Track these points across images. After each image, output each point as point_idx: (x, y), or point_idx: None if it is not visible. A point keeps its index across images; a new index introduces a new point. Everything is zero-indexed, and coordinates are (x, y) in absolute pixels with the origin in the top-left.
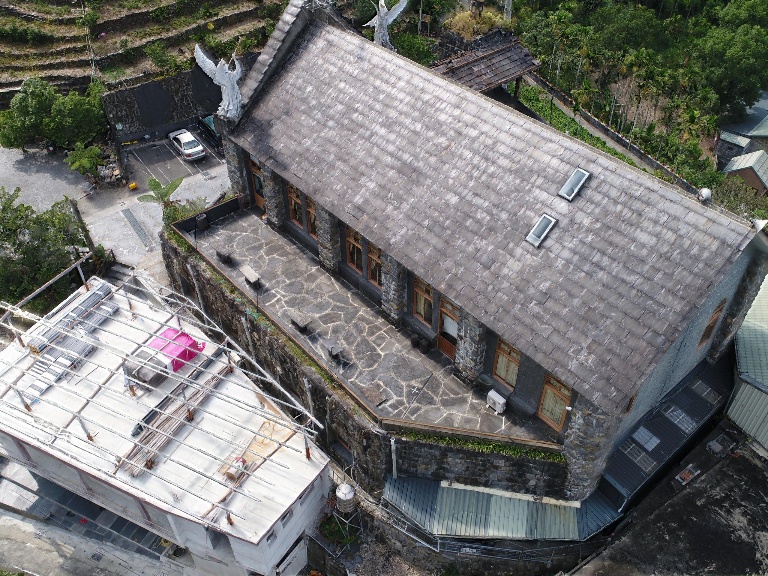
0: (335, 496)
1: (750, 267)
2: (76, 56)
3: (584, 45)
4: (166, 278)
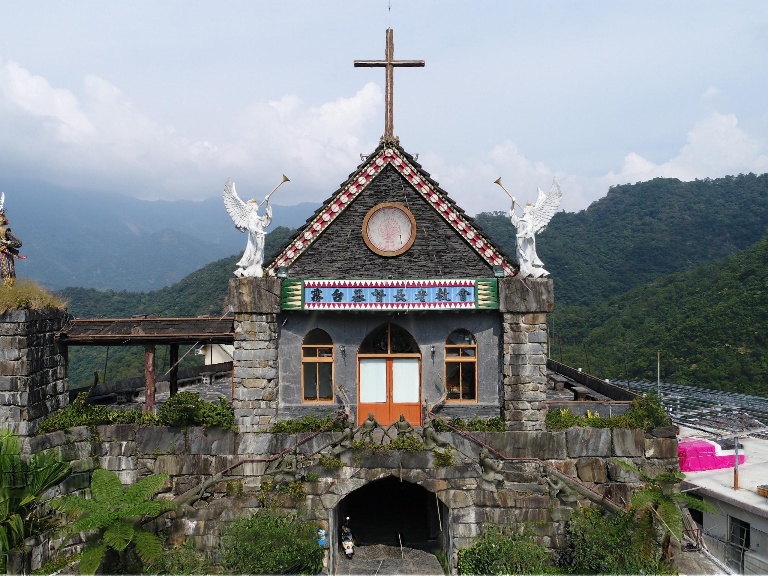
0: None
1: None
2: None
3: None
4: (691, 567)
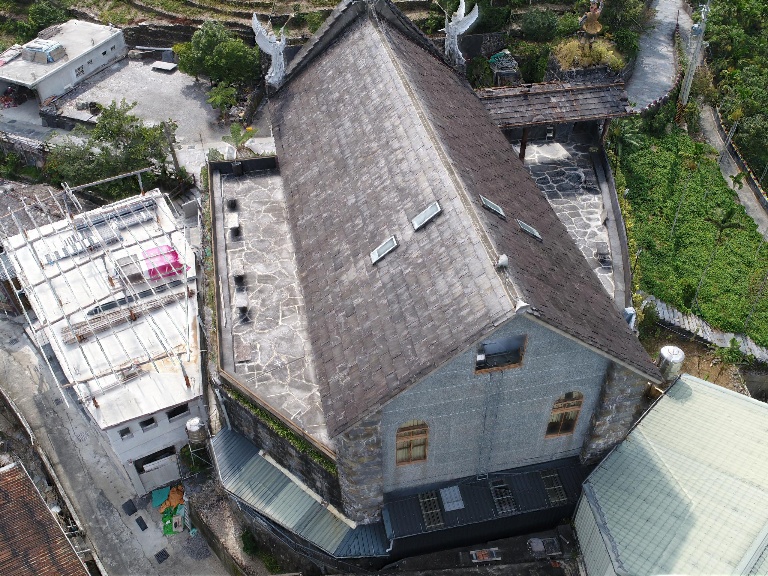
0: None
1: (609, 369)
2: (262, 10)
3: (739, 109)
4: None
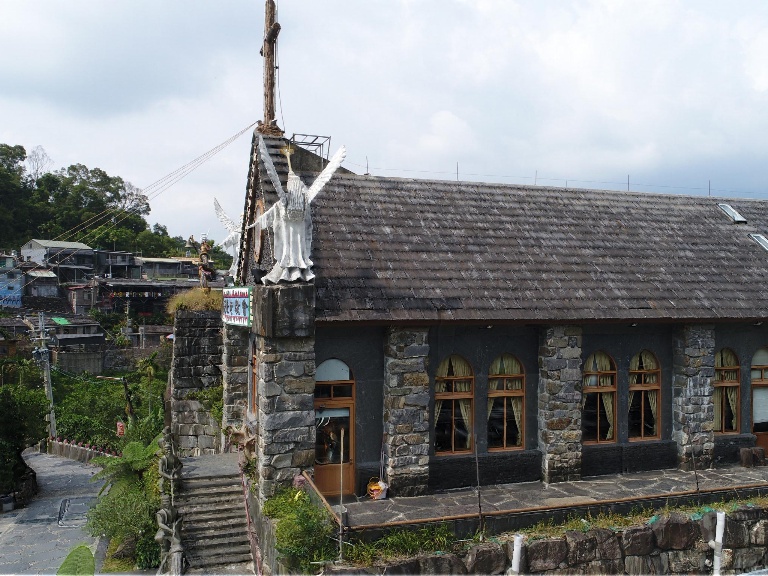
0: None
1: None
2: None
3: None
4: None
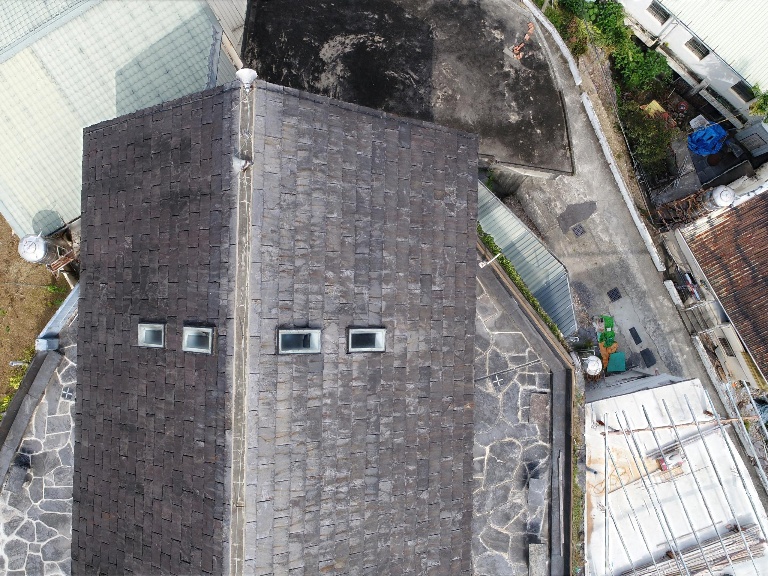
0: (591, 378)
1: None
2: None
3: None
4: None
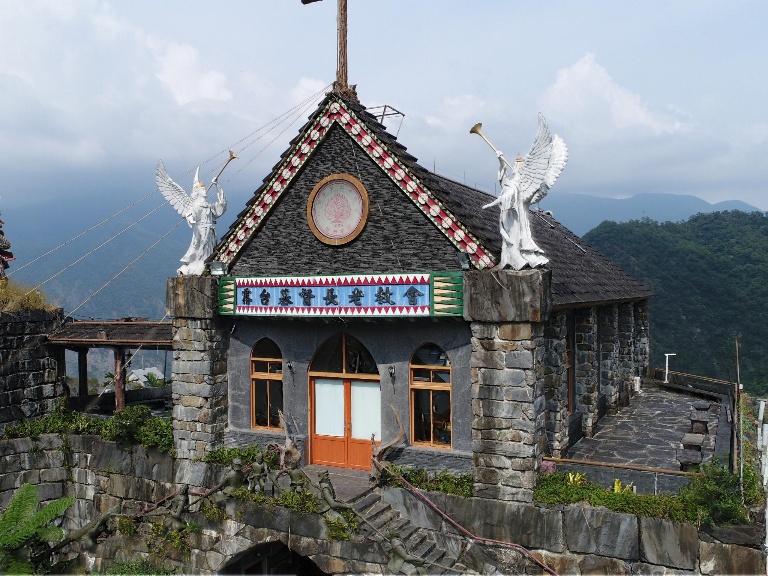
0: None
1: None
2: None
3: None
4: None
